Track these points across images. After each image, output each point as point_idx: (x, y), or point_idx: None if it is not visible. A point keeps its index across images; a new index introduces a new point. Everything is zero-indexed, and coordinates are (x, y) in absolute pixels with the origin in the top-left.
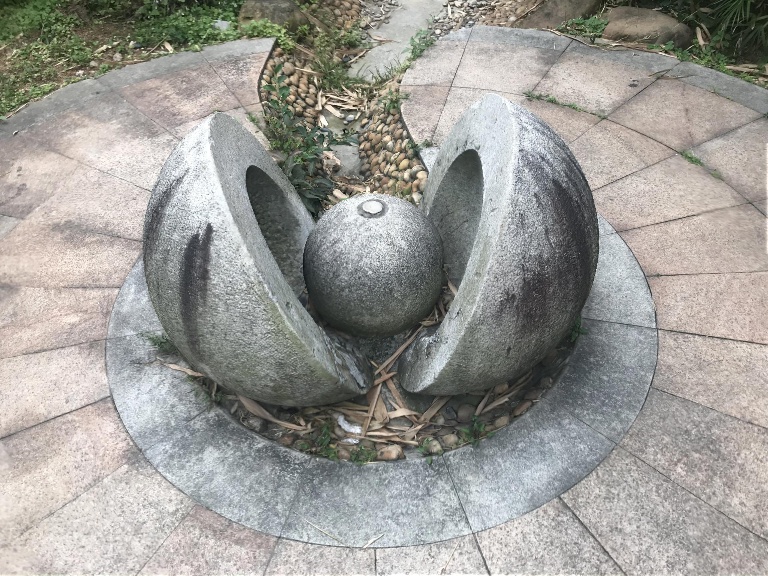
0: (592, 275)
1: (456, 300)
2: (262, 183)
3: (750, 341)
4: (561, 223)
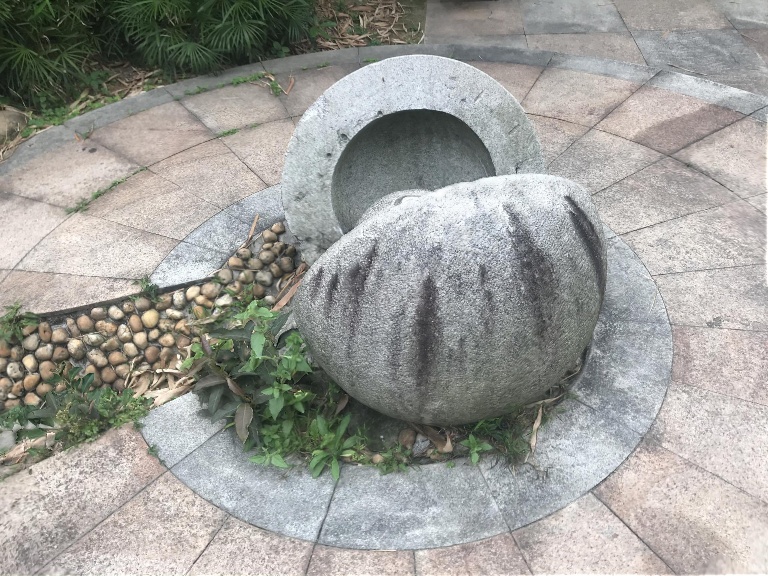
0: None
1: (502, 171)
2: None
3: None
4: None
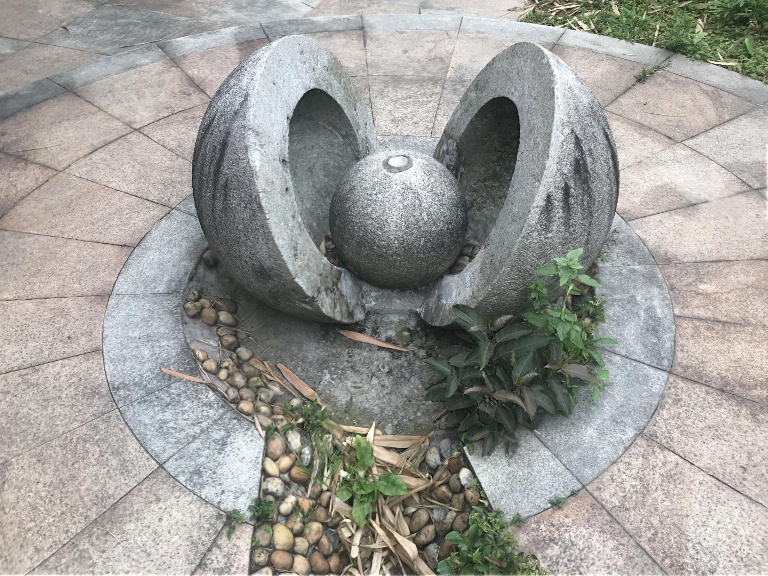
0: None
1: None
2: None
3: (117, 191)
4: None
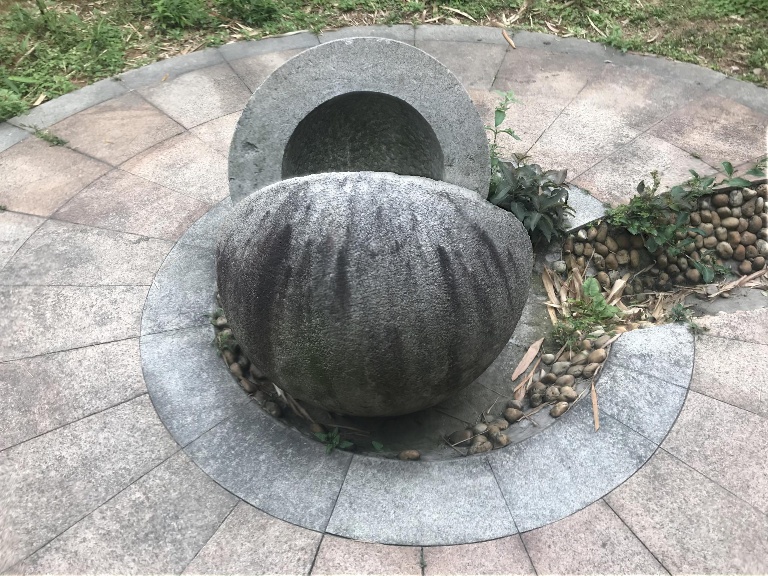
0: (278, 350)
1: None
2: (431, 134)
3: None
4: (260, 253)
